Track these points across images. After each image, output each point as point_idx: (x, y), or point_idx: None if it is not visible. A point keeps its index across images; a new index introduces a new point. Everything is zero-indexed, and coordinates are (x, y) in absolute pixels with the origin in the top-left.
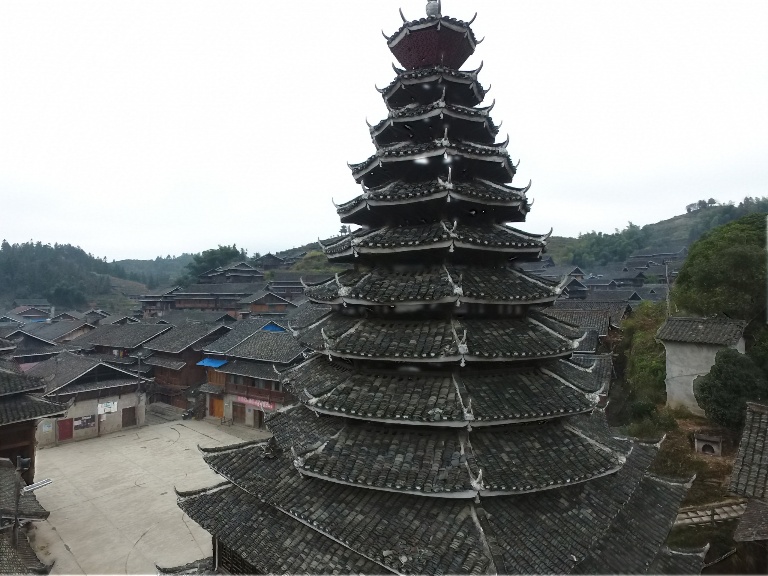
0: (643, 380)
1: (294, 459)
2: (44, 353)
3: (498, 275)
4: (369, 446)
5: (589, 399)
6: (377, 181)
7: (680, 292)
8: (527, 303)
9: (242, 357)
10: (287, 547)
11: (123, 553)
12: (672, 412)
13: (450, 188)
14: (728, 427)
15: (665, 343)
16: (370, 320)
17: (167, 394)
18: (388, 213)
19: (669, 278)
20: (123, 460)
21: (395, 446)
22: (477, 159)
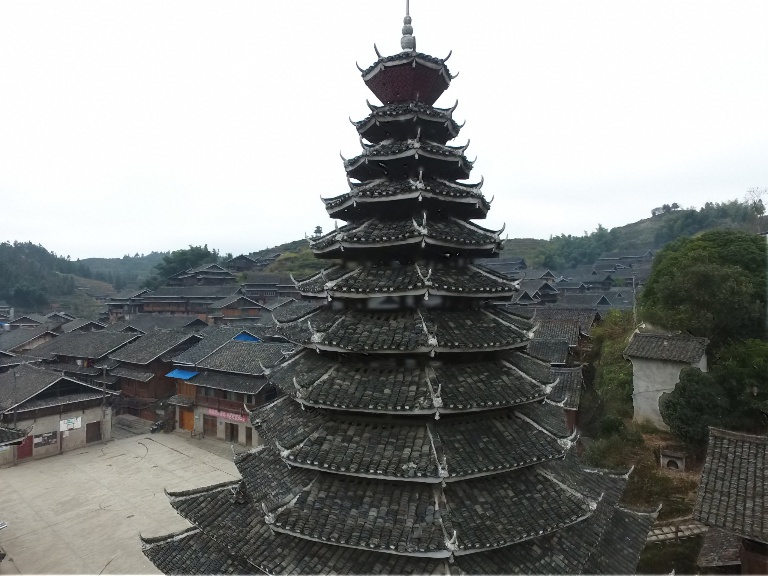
0: (611, 394)
1: (265, 514)
2: (1, 365)
3: (472, 318)
4: (342, 498)
5: (561, 445)
6: (351, 216)
7: (646, 308)
8: (501, 349)
9: (213, 369)
10: None
11: None
12: (639, 427)
13: (425, 234)
14: (691, 444)
15: (632, 359)
16: (344, 364)
17: (134, 407)
18: (362, 254)
19: (636, 288)
20: (87, 480)
21: (369, 499)
22: (452, 201)
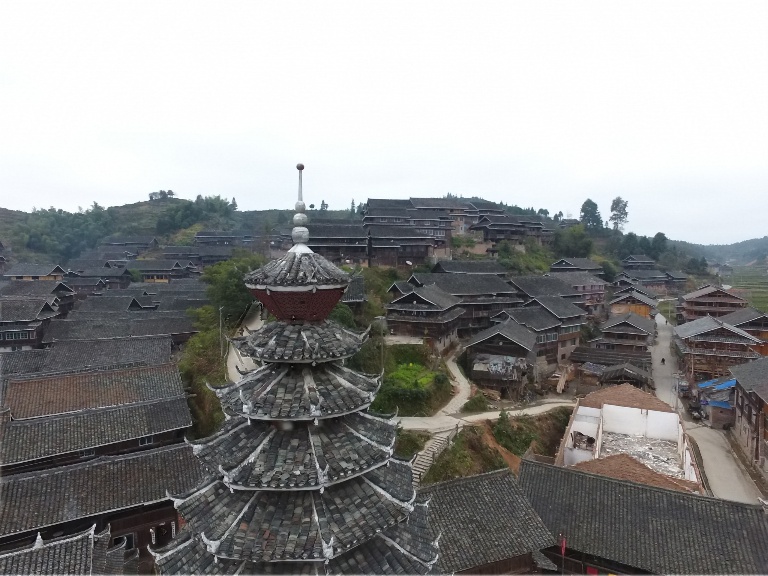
0: None
1: None
2: None
3: None
4: None
5: None
6: None
7: None
8: None
9: None
10: None
11: None
12: None
13: None
14: None
15: None
16: None
17: None
18: None
19: (222, 322)
20: None
21: None
22: None
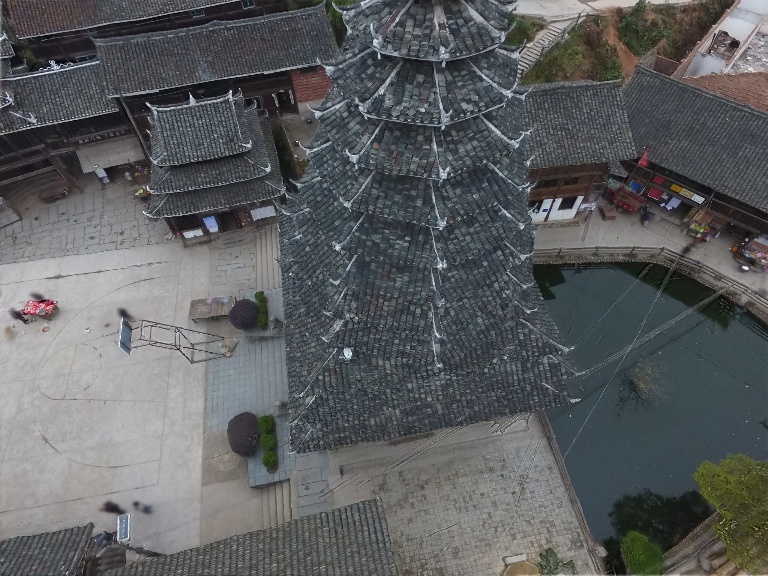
0: None
1: None
2: None
3: None
4: None
5: (528, 214)
6: None
7: None
8: None
9: None
10: (413, 387)
11: (62, 464)
12: None
13: None
14: None
15: None
16: None
17: None
18: None
19: None
20: None
21: None
22: None
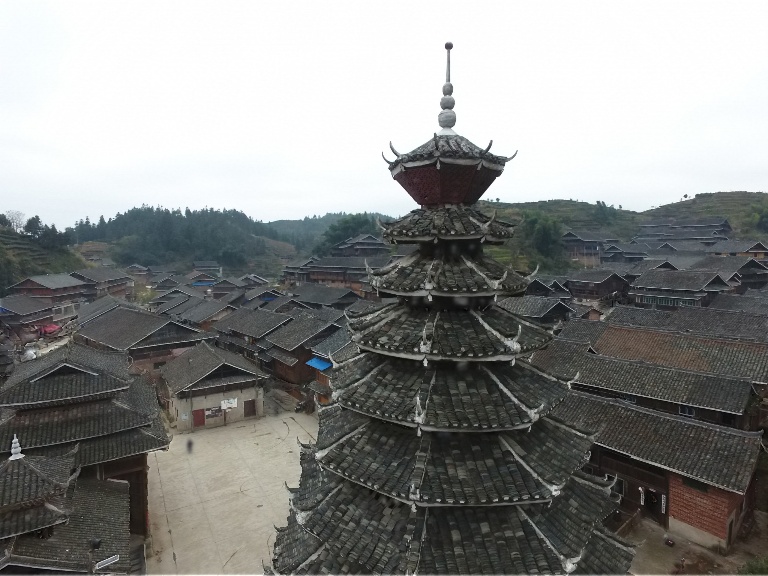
0: None
1: None
2: (190, 340)
3: (492, 519)
4: None
5: None
6: None
7: None
8: None
9: None
10: None
11: (213, 575)
12: None
13: (419, 422)
14: None
15: None
16: None
17: None
18: None
19: None
20: (237, 457)
21: None
22: (473, 361)
